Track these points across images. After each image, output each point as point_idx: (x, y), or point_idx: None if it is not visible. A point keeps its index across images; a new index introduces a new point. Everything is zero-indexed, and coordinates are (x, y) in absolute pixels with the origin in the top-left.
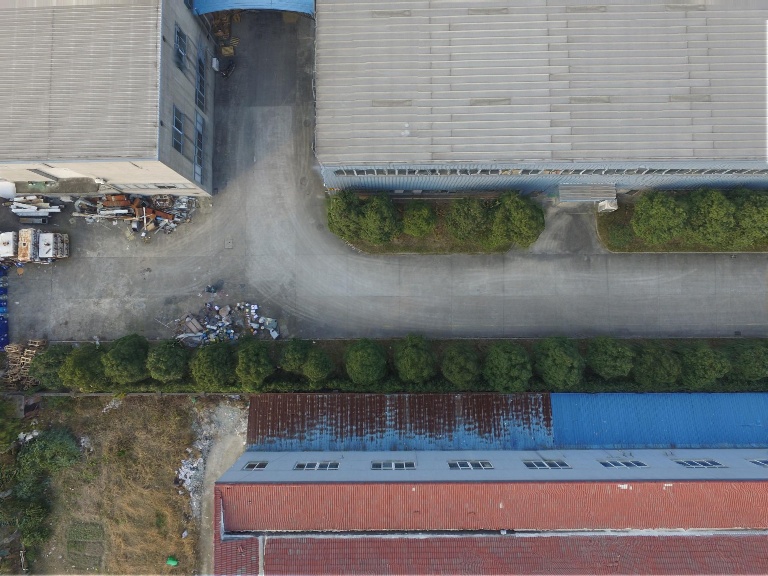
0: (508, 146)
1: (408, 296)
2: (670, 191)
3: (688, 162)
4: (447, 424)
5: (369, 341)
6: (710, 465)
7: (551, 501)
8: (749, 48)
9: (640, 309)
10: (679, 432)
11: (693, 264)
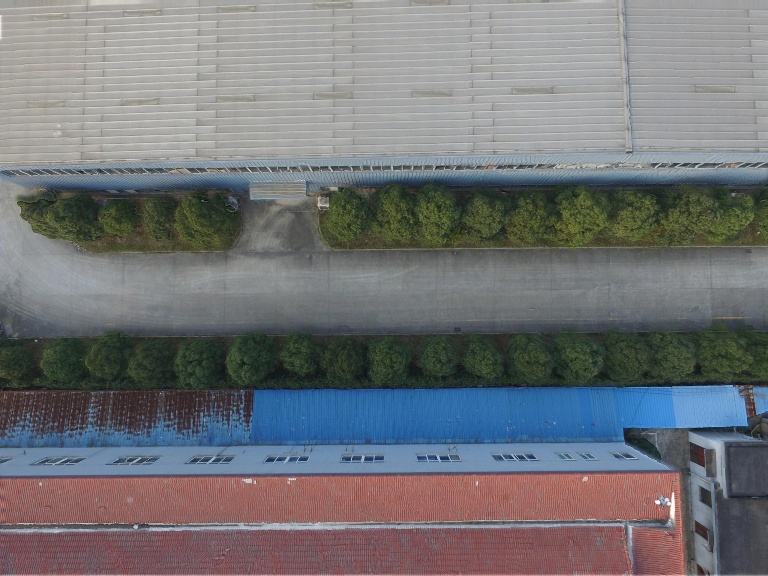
0: (155, 145)
1: (131, 294)
2: (372, 188)
3: (336, 159)
4: (147, 421)
5: (68, 339)
6: (371, 460)
7: (169, 495)
8: (406, 45)
9: (360, 306)
10: (376, 428)
11: (415, 261)
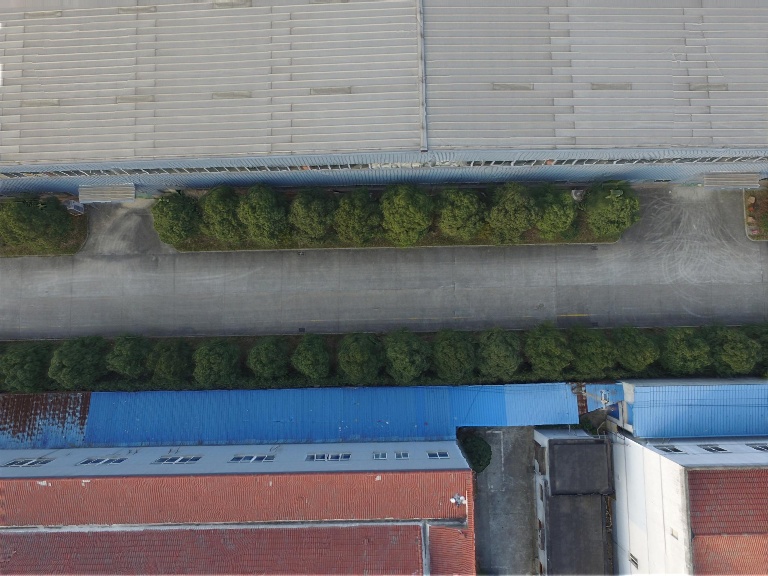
0: None
1: None
2: None
3: (142, 161)
4: None
5: None
6: (184, 461)
7: None
8: (215, 47)
9: (205, 307)
10: (210, 429)
11: (260, 262)
